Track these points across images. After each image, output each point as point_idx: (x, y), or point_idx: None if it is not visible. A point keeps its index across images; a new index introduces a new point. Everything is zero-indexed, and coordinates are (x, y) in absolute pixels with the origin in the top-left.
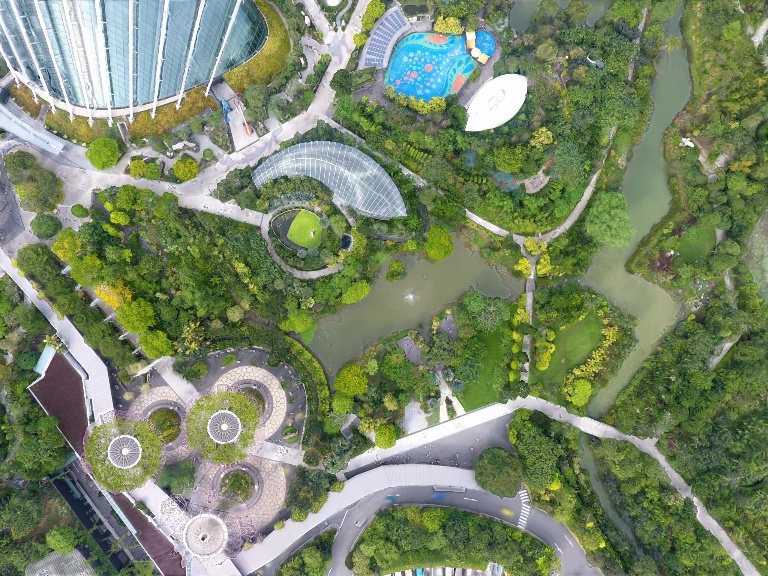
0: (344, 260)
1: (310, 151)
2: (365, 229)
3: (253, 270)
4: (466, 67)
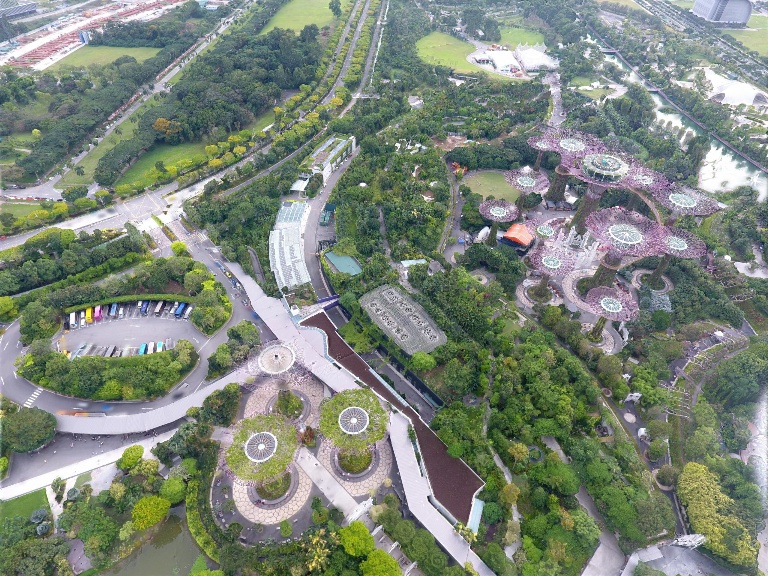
0: None
1: None
2: None
3: None
4: None
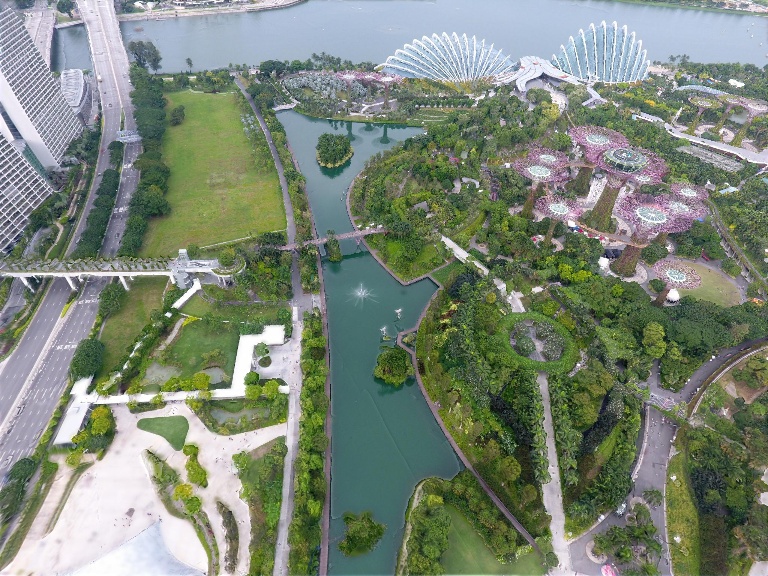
0: None
1: None
2: None
3: None
4: None
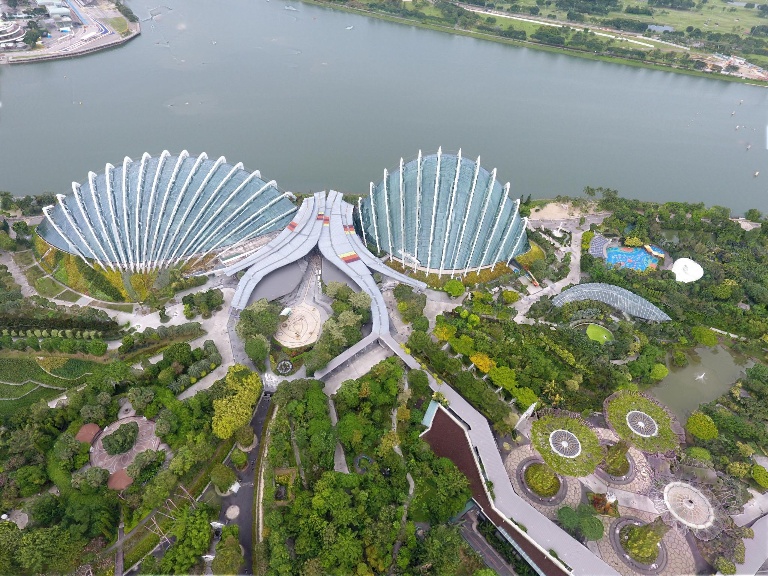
0: (639, 349)
1: (588, 287)
2: (645, 329)
3: (575, 356)
4: (652, 260)
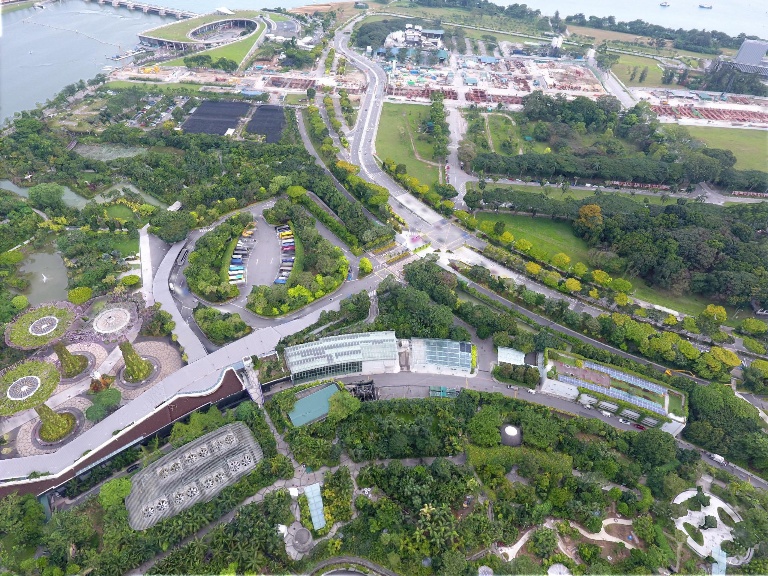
0: None
1: None
2: None
3: None
4: None
